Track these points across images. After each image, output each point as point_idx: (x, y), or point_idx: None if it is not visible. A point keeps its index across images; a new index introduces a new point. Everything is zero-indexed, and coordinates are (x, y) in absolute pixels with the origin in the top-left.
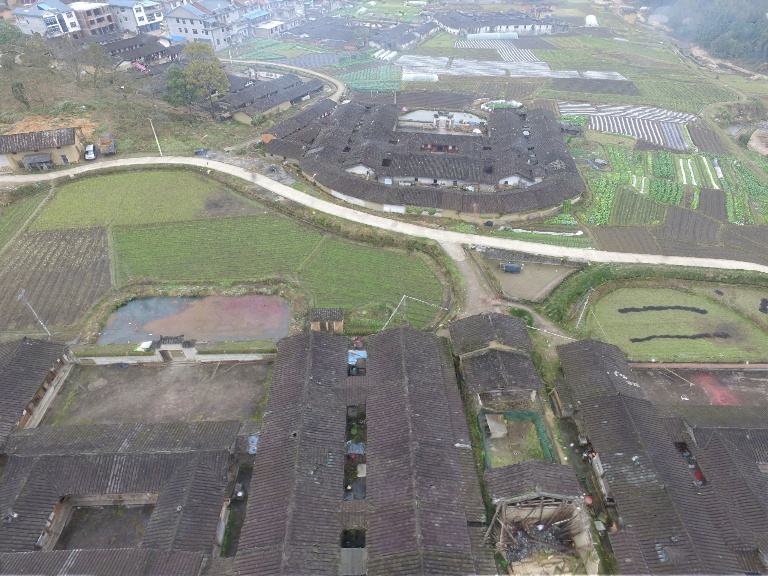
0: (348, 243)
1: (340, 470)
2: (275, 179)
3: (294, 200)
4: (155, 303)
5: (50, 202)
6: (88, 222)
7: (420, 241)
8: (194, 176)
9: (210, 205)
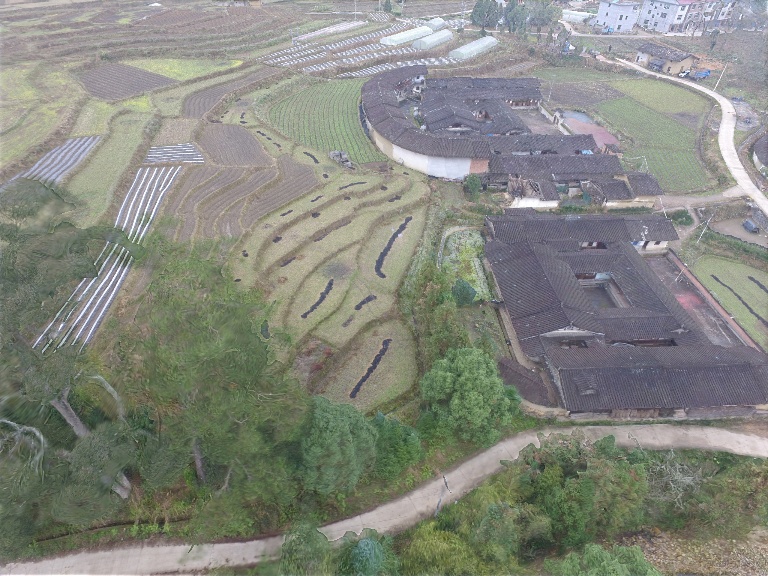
0: (696, 158)
1: (523, 149)
2: (738, 124)
3: (719, 133)
4: (586, 117)
5: (631, 80)
6: (625, 91)
7: (728, 178)
8: (706, 104)
9: (680, 114)
